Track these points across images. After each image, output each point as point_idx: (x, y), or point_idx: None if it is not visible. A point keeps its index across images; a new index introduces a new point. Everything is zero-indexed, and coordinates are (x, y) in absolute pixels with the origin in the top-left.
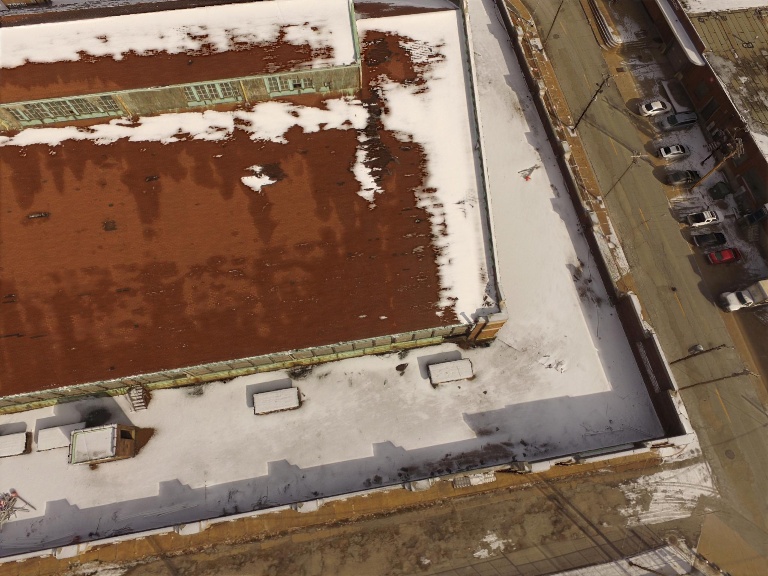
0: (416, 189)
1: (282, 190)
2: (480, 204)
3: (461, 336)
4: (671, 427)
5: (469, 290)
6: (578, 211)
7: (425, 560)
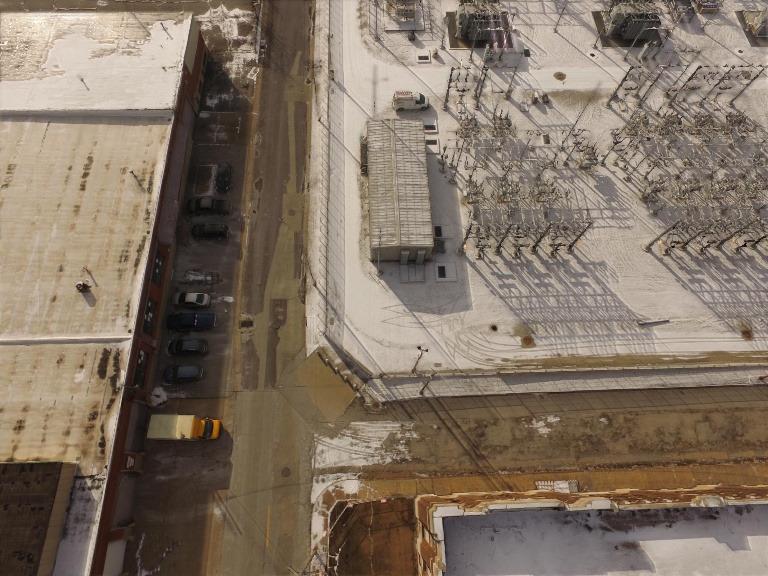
0: None
1: None
2: None
3: None
4: None
5: None
6: None
7: (604, 421)
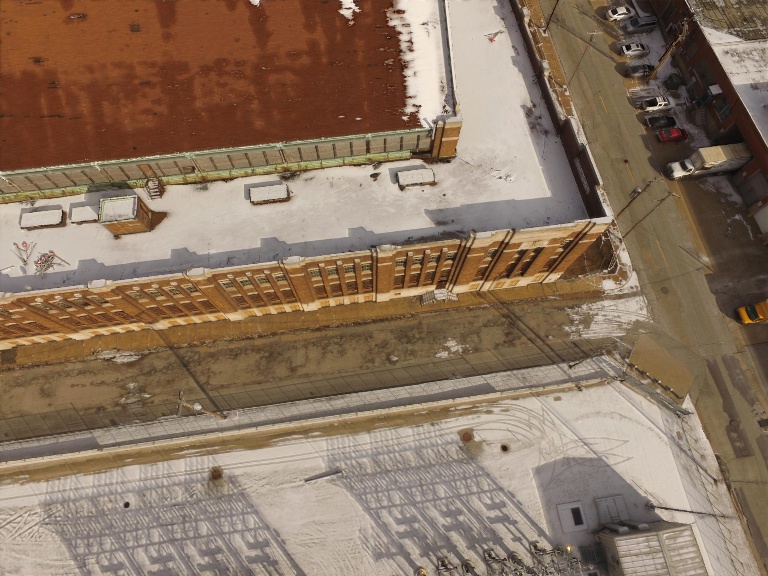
0: (388, 10)
1: (277, 5)
2: (441, 26)
3: (426, 154)
4: (597, 217)
5: (431, 99)
6: (534, 65)
7: (394, 358)
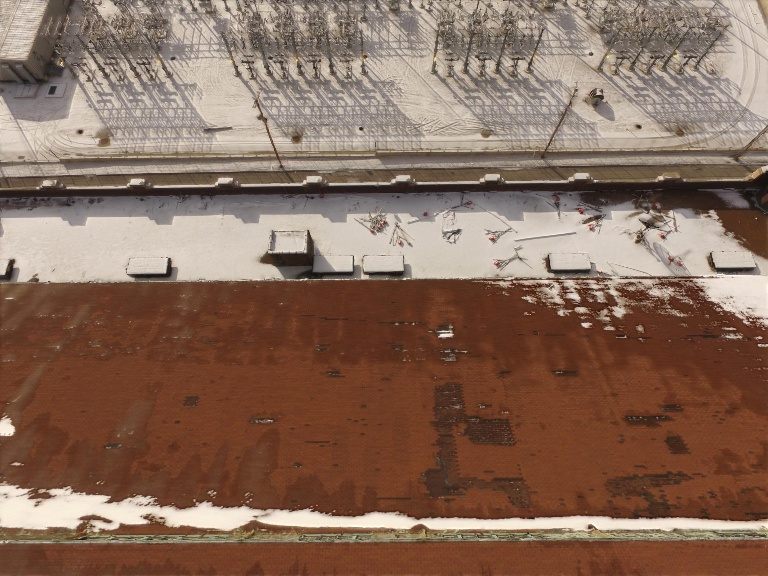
0: None
1: None
2: None
3: None
4: None
5: None
6: None
7: None
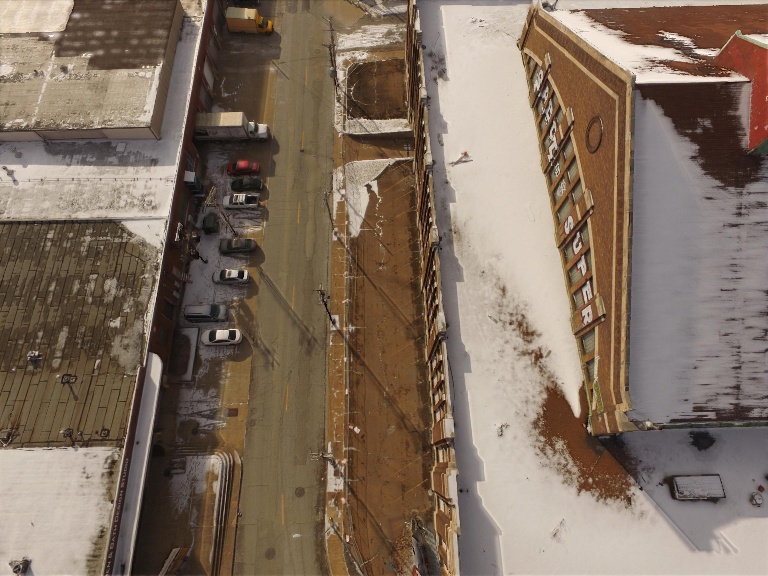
0: None
1: None
2: None
3: None
4: None
5: None
6: None
7: None
